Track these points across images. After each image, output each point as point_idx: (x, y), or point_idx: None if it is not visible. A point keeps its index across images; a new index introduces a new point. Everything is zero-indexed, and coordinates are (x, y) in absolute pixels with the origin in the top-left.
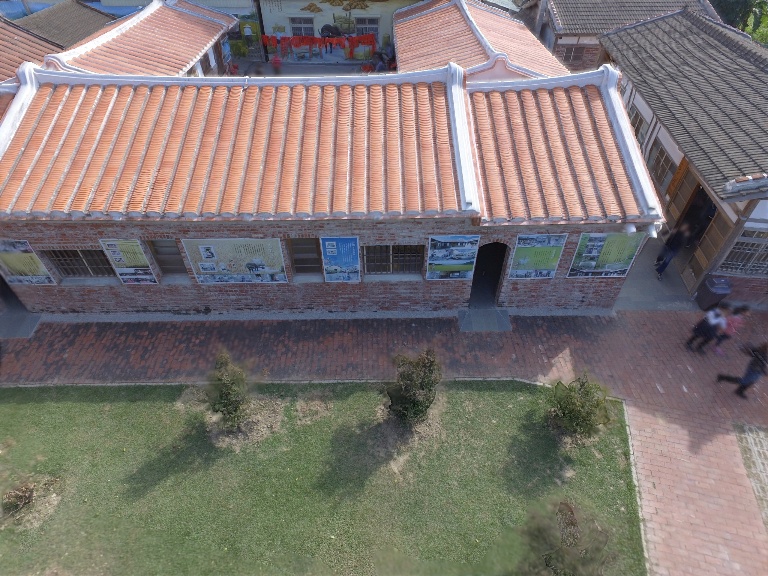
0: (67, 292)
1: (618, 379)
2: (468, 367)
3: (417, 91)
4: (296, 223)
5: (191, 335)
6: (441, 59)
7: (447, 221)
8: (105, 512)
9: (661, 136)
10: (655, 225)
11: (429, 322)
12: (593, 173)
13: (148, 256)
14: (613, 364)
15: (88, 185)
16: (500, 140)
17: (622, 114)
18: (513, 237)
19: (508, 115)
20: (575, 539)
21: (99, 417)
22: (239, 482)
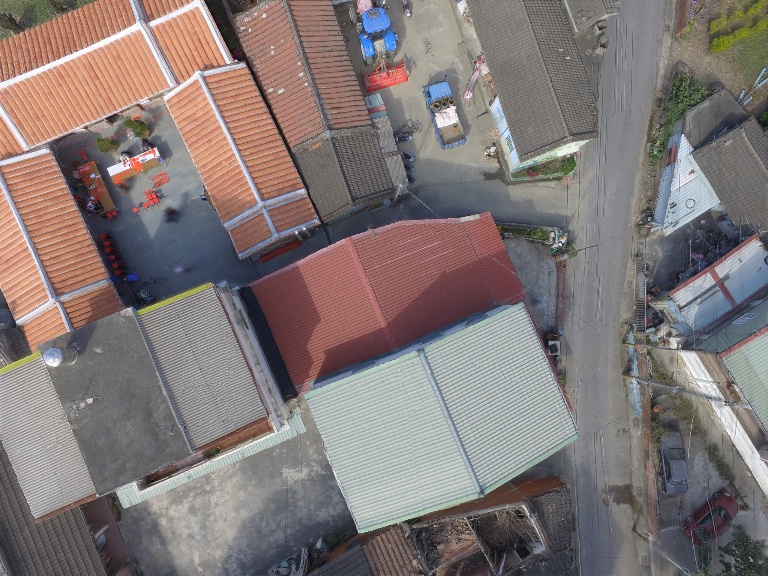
0: None
1: None
2: None
3: (3, 80)
4: None
5: None
6: (36, 185)
7: None
8: None
9: None
10: None
11: None
12: None
13: None
14: None
15: (98, 8)
16: None
17: None
18: None
19: None
20: None
21: None
22: None
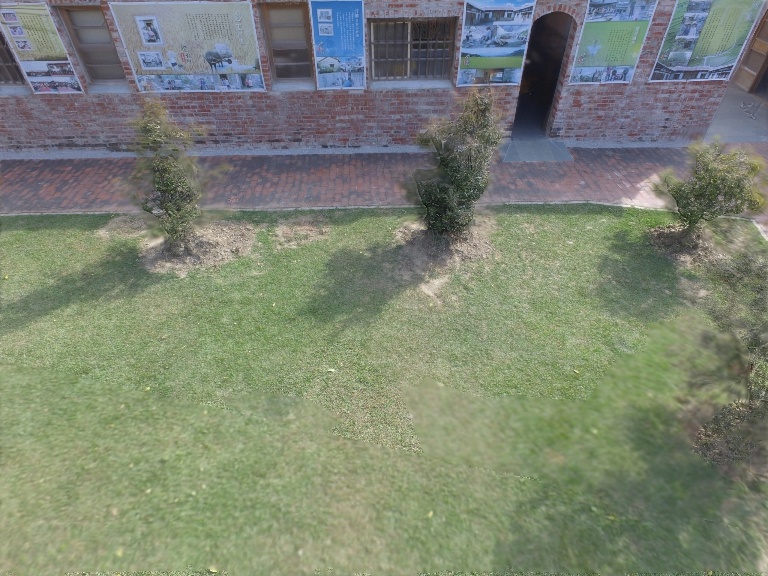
0: None
1: None
2: (521, 192)
3: None
4: None
5: (131, 169)
6: None
7: None
8: None
9: None
10: None
11: None
12: None
13: (65, 39)
14: None
15: None
16: None
17: None
18: (582, 1)
19: None
20: None
21: None
22: (181, 309)
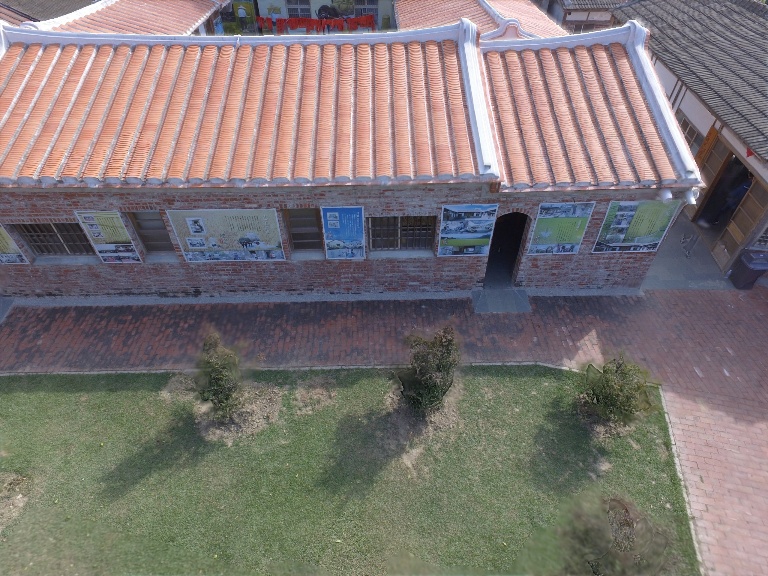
0: (42, 272)
1: (652, 362)
2: (485, 351)
3: (426, 50)
4: (294, 191)
5: (179, 319)
6: None
7: (462, 188)
8: (78, 515)
9: (684, 107)
10: (693, 191)
11: (440, 303)
12: (622, 135)
13: (130, 230)
14: (645, 346)
15: (61, 149)
16: (518, 101)
17: (651, 73)
18: (535, 206)
19: (526, 75)
20: (630, 542)
21: (74, 408)
22: (231, 479)
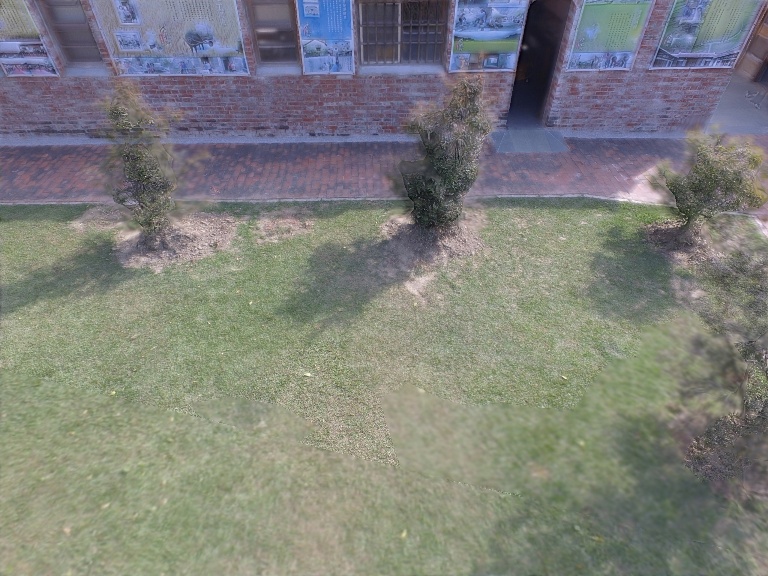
0: None
1: None
2: (514, 184)
3: None
4: None
5: (110, 157)
6: None
7: None
8: None
9: None
10: None
11: None
12: None
13: (36, 18)
14: None
15: None
16: None
17: None
18: None
19: None
20: None
21: None
22: (153, 307)
